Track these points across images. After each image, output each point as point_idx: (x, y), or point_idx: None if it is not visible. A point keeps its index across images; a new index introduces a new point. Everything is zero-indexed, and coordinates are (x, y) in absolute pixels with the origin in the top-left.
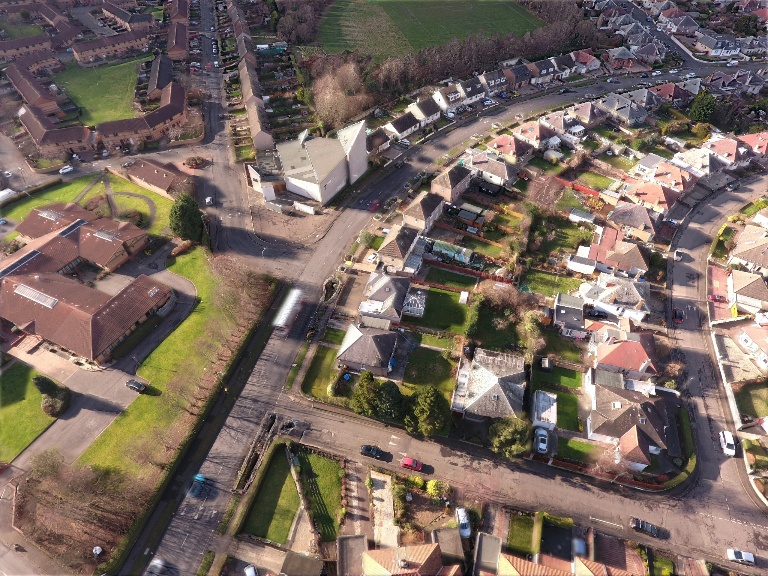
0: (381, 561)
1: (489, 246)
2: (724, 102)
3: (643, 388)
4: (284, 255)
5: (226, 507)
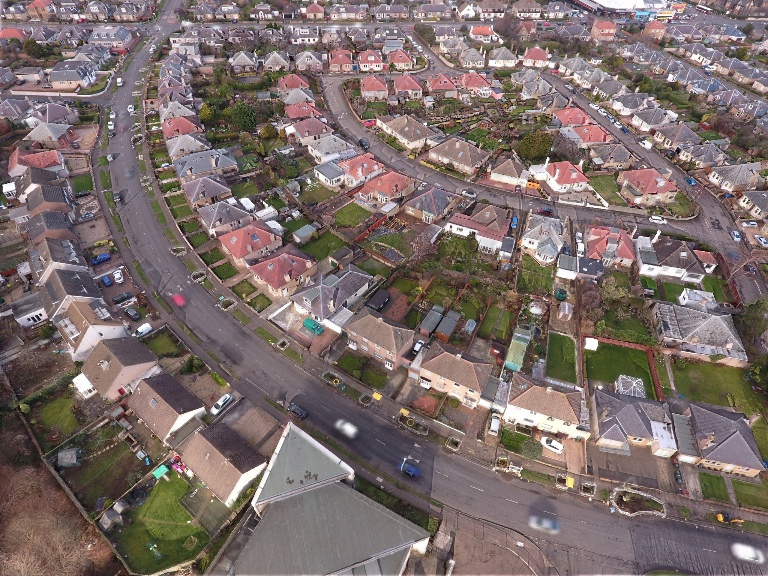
0: None
1: (490, 316)
2: None
3: (645, 242)
4: None
5: None
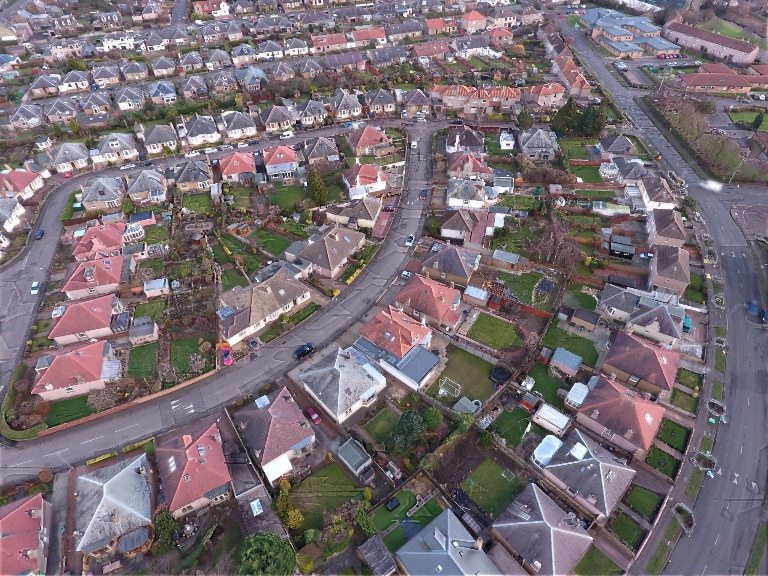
0: (557, 88)
1: None
2: None
3: None
4: (741, 198)
5: (624, 111)
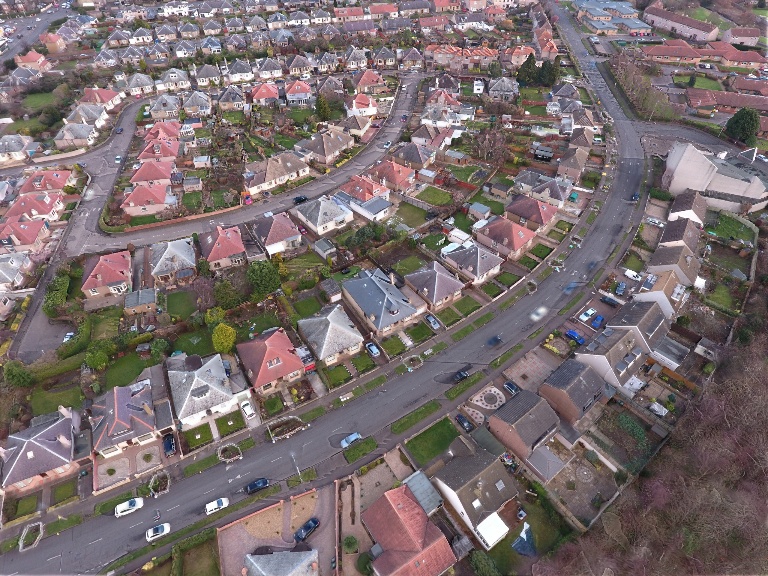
0: (528, 50)
1: (521, 141)
2: (228, 280)
3: None
4: (654, 130)
5: None
